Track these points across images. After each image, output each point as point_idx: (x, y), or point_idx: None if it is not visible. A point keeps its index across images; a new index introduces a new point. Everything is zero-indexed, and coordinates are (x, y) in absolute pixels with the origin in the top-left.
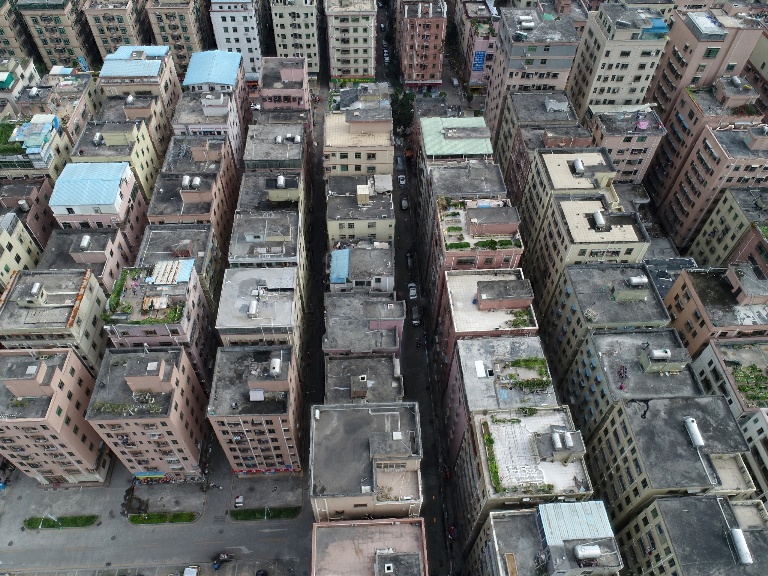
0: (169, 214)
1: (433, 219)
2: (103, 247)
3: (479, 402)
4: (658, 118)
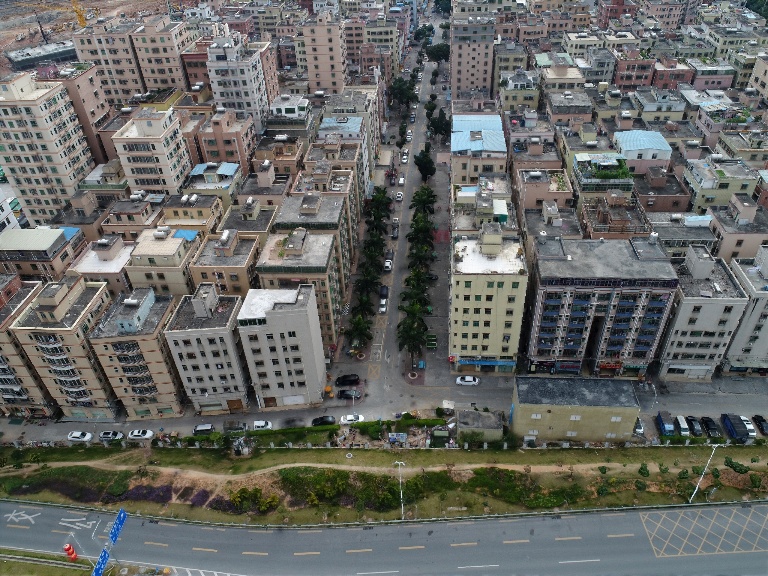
0: None
1: None
2: None
3: (729, 68)
4: (506, 38)
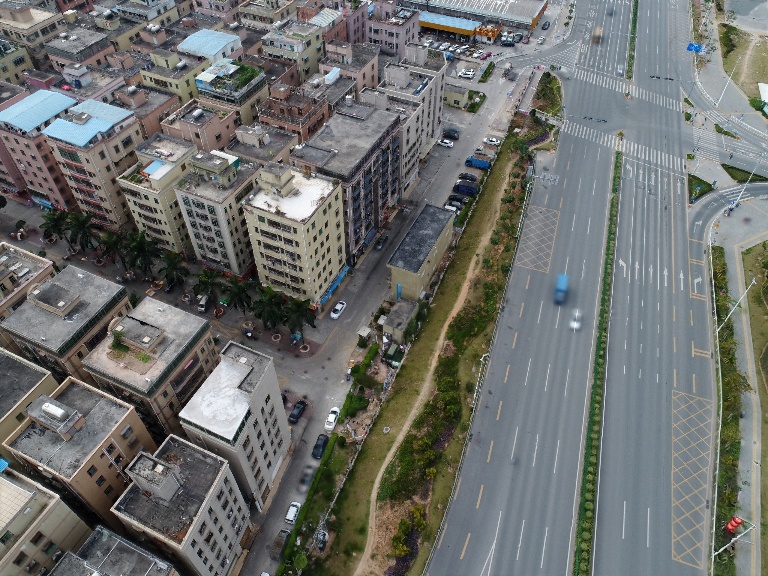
0: (180, 37)
1: (55, 5)
2: (227, 26)
3: None
4: None
